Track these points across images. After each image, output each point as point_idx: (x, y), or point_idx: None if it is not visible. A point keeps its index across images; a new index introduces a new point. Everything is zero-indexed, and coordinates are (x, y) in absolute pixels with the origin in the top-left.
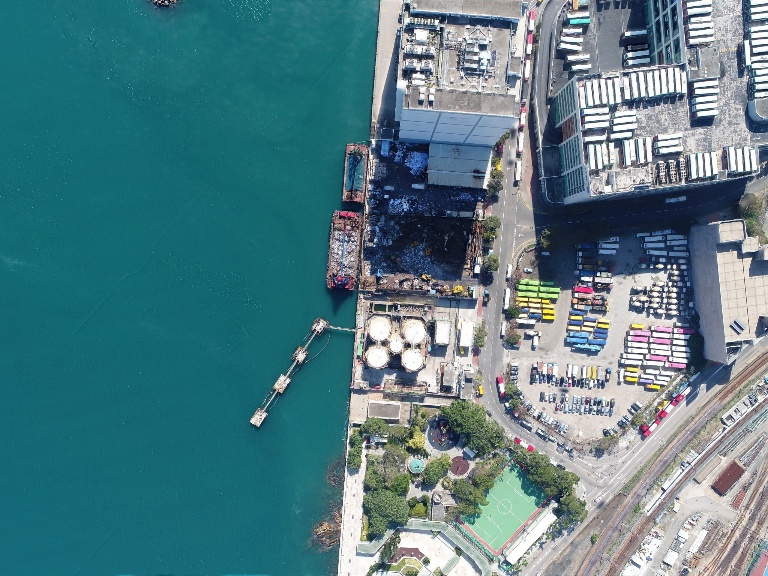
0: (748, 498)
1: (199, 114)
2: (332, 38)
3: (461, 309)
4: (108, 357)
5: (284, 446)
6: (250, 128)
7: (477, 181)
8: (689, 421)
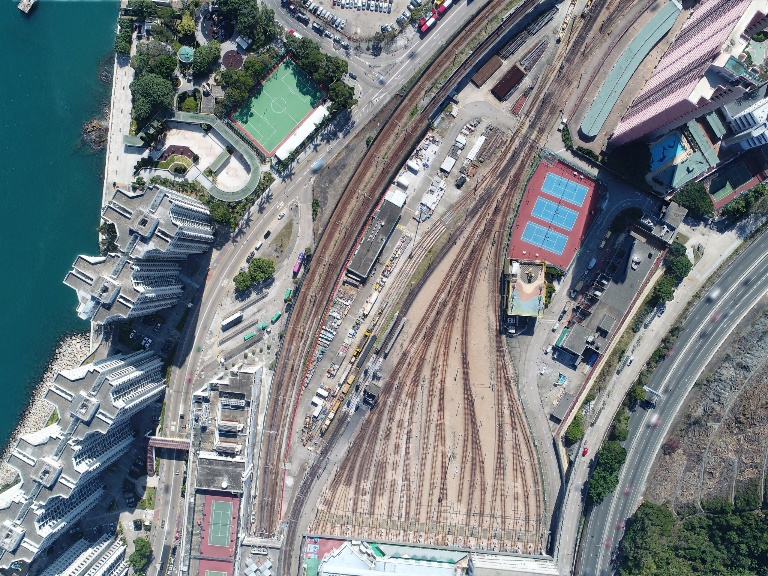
0: (529, 105)
1: None
2: None
3: None
4: None
5: (55, 39)
6: None
7: None
8: (468, 19)
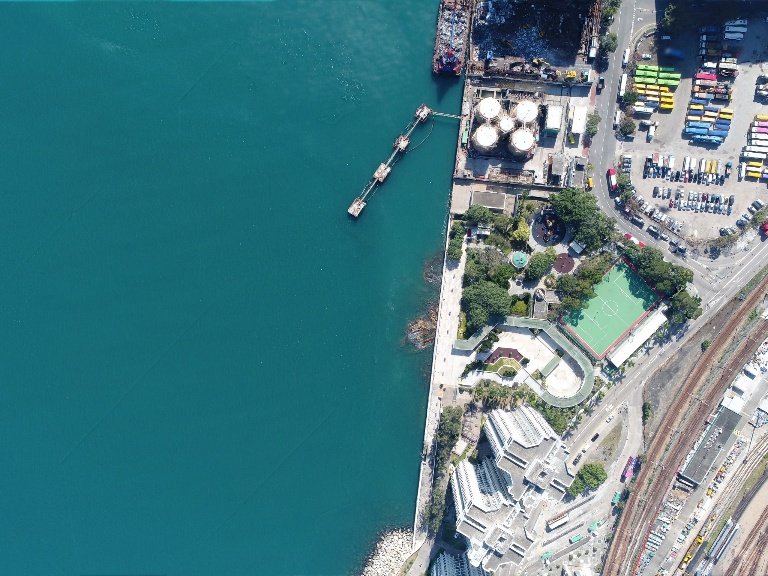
0: None
1: None
2: None
3: (573, 97)
4: (213, 124)
5: (381, 240)
6: None
7: None
8: None
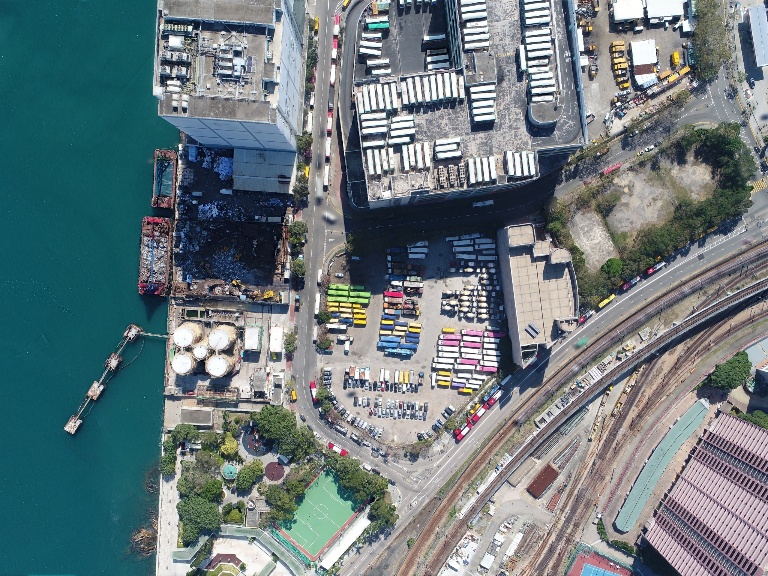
0: (563, 501)
1: (8, 120)
2: (140, 43)
3: (273, 314)
4: None
5: (101, 453)
6: (60, 134)
7: (283, 186)
8: (502, 424)
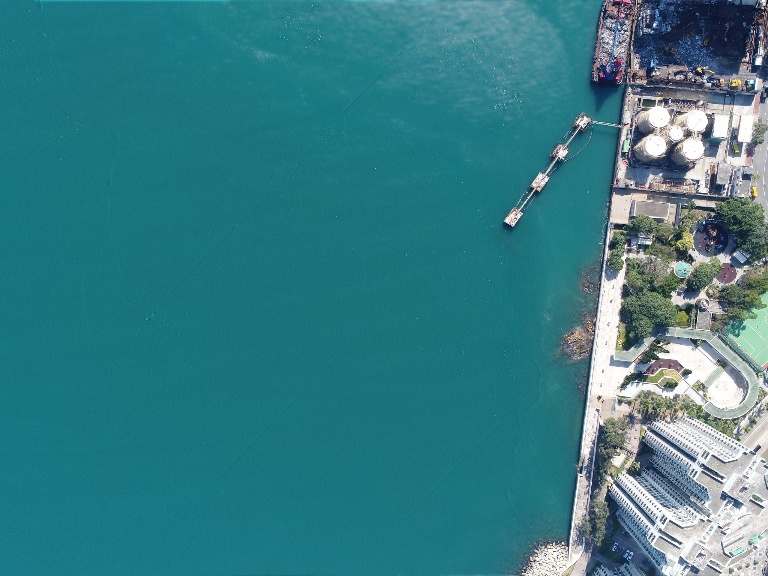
0: None
1: None
2: None
3: (736, 106)
4: (379, 134)
5: (536, 250)
6: None
7: None
8: None
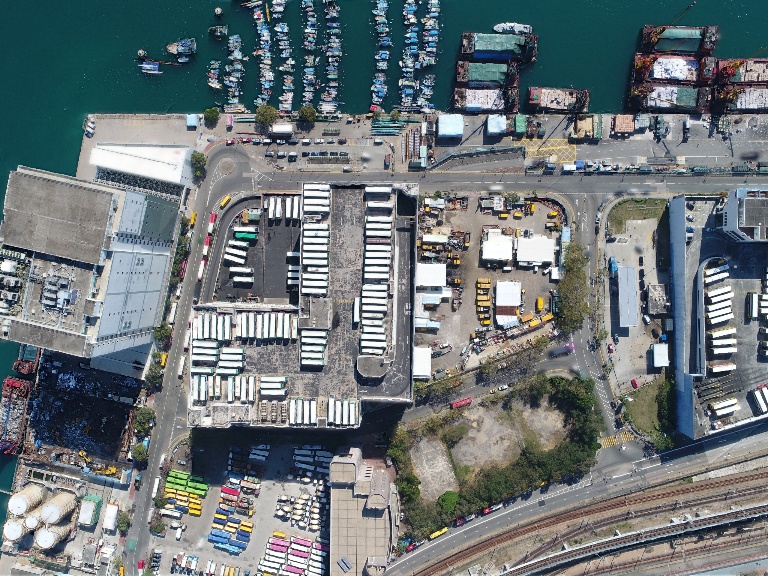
0: None
1: None
2: None
3: (115, 489)
4: None
5: None
6: None
7: (136, 372)
8: None
